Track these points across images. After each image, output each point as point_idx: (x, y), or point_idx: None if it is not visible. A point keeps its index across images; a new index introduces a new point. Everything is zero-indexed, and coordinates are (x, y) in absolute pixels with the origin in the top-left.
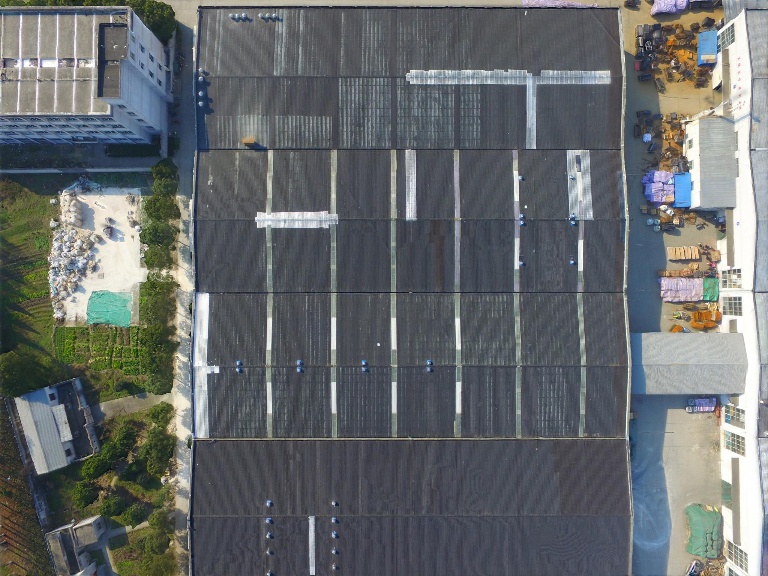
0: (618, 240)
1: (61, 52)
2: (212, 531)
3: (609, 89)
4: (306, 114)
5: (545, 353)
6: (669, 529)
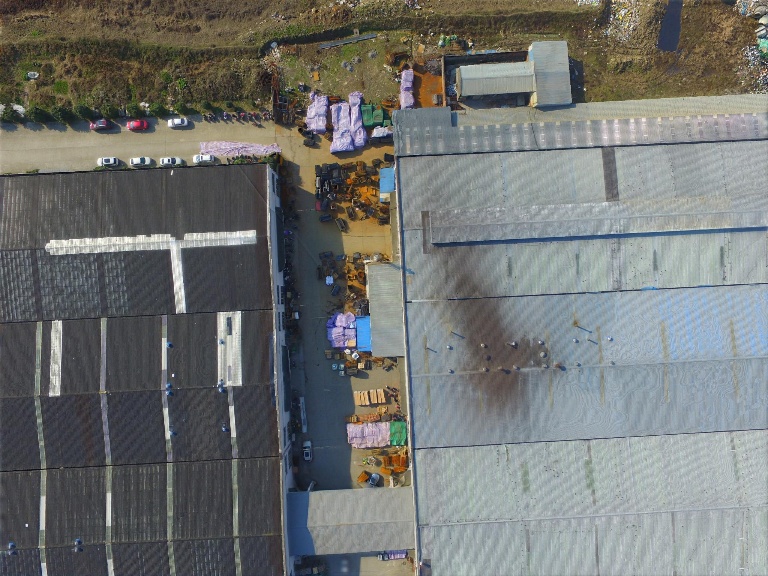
0: (269, 404)
1: None
2: None
3: (256, 249)
4: None
5: (197, 525)
6: None
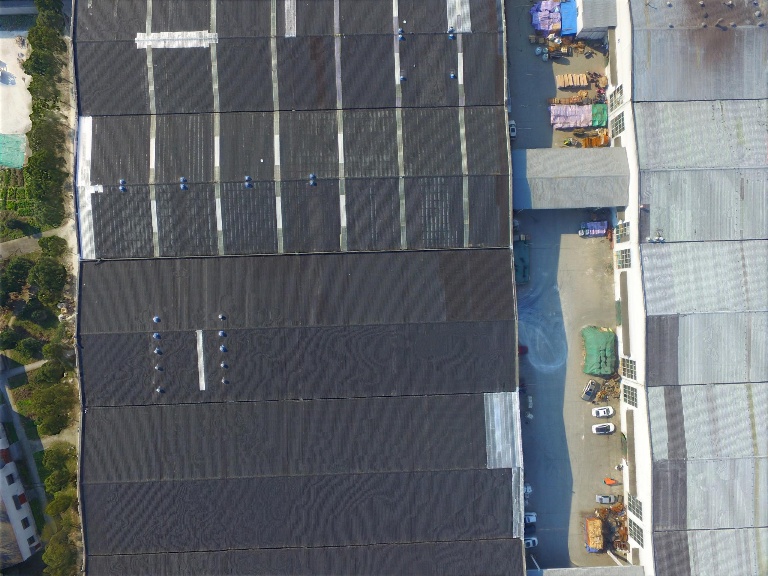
0: (497, 53)
1: None
2: (100, 348)
3: None
4: None
5: (427, 164)
6: (565, 351)
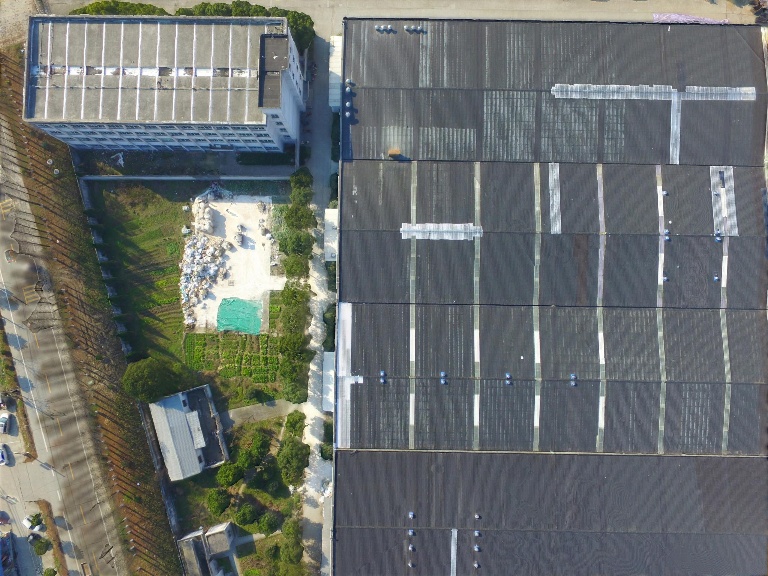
0: (763, 257)
1: (216, 61)
2: (354, 542)
3: (754, 106)
4: (450, 126)
5: (689, 369)
6: None
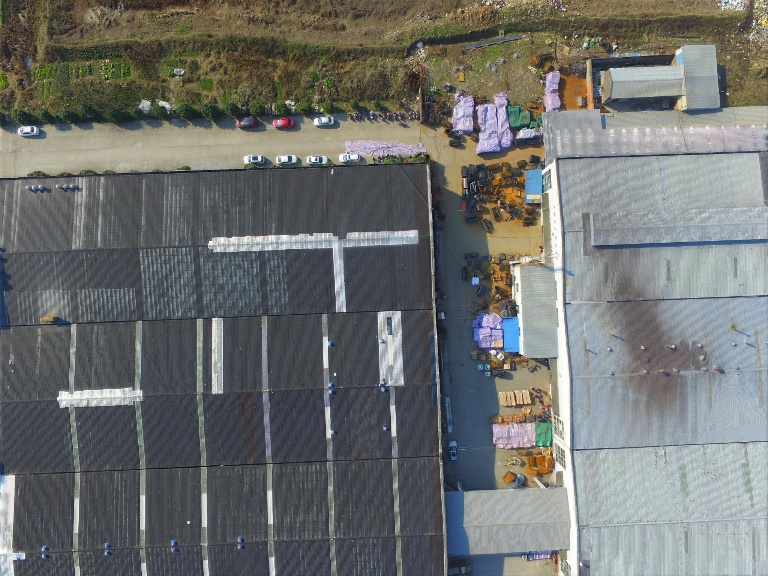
0: (431, 404)
1: None
2: None
3: (417, 249)
4: (108, 287)
5: (359, 524)
6: None
